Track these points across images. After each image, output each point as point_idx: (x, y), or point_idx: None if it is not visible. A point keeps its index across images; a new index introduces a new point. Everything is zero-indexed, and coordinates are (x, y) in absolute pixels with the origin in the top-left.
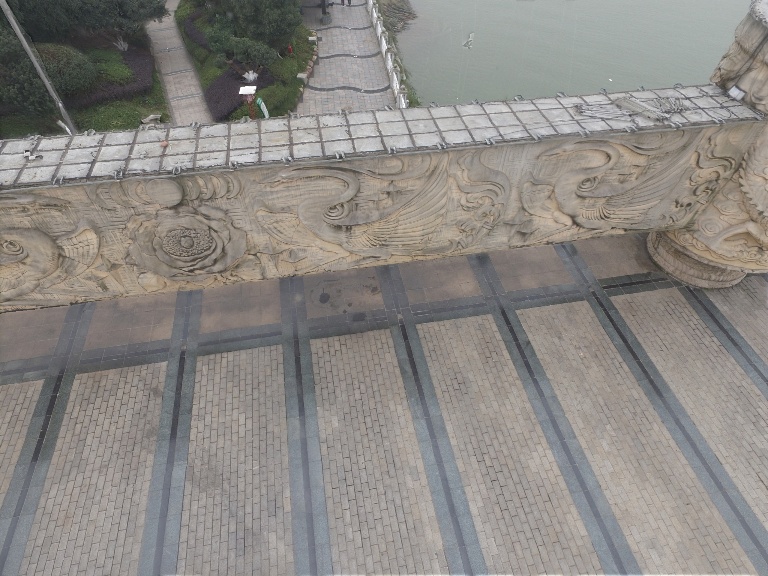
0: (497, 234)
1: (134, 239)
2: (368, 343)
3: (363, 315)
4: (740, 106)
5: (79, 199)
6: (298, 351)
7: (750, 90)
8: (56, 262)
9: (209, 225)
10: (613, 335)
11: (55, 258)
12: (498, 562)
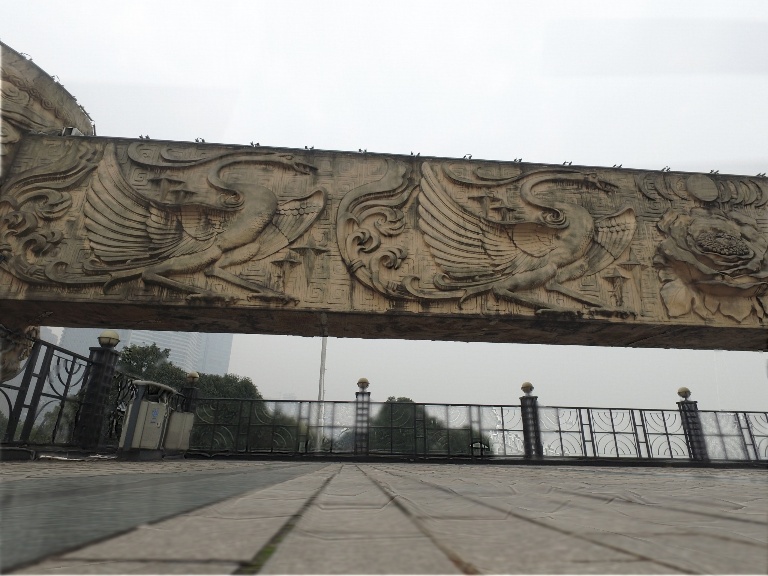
0: None
1: (667, 234)
2: None
3: None
4: None
5: (626, 186)
6: None
7: None
8: (587, 244)
9: (740, 232)
10: None
11: (590, 237)
12: None
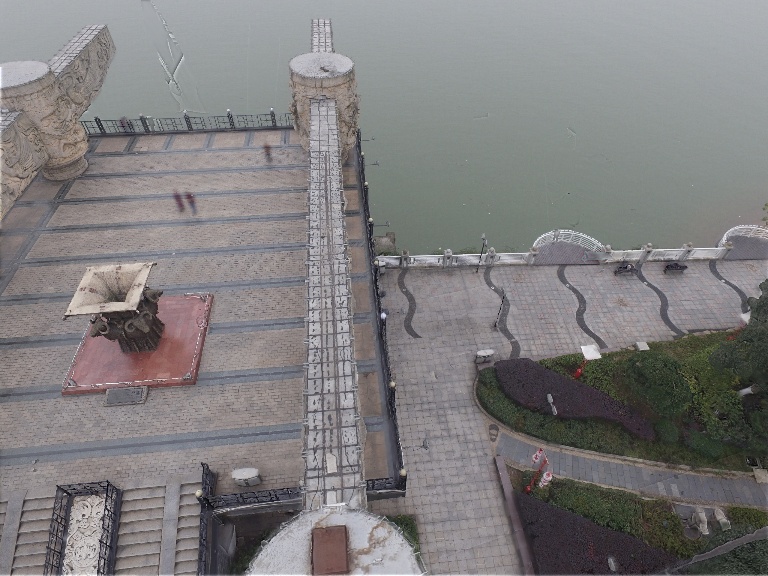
0: (5, 200)
1: None
2: (21, 276)
3: (3, 277)
4: (12, 113)
5: None
6: (3, 300)
7: (8, 108)
8: None
9: None
10: (81, 203)
11: None
12: (130, 250)
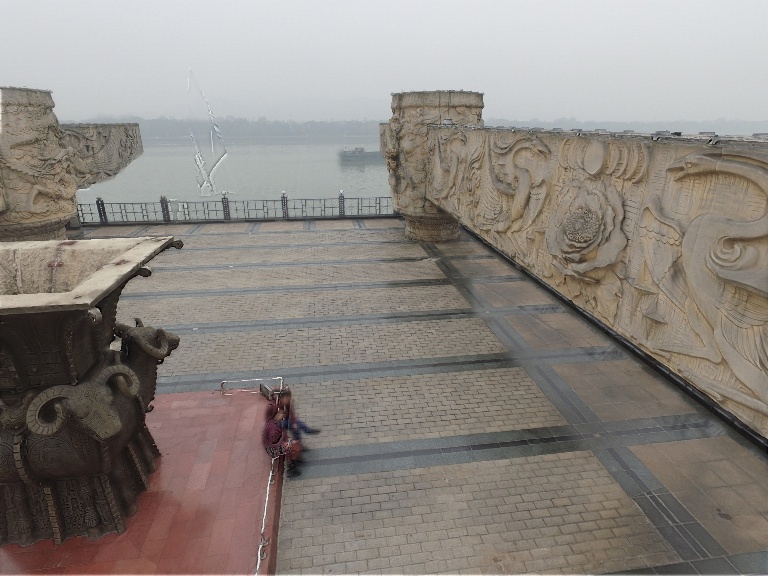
0: None
1: None
2: None
3: None
4: None
5: None
6: None
7: None
8: None
9: None
10: None
11: None
12: None
